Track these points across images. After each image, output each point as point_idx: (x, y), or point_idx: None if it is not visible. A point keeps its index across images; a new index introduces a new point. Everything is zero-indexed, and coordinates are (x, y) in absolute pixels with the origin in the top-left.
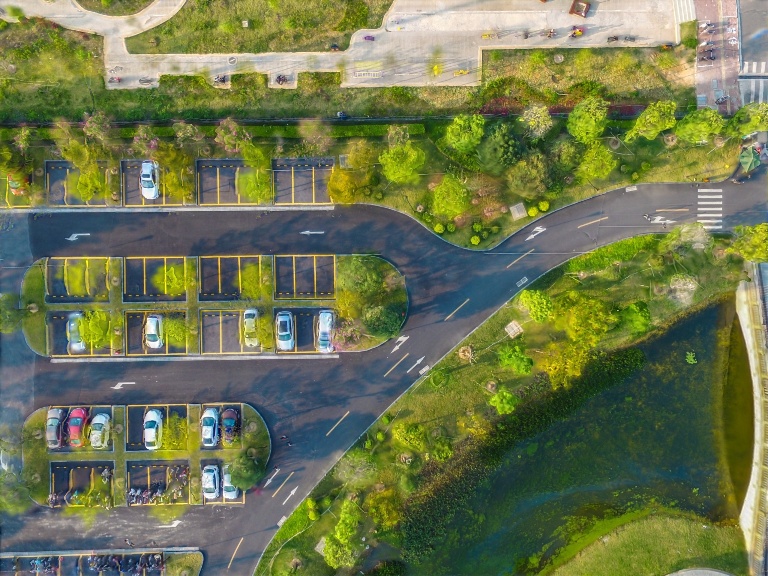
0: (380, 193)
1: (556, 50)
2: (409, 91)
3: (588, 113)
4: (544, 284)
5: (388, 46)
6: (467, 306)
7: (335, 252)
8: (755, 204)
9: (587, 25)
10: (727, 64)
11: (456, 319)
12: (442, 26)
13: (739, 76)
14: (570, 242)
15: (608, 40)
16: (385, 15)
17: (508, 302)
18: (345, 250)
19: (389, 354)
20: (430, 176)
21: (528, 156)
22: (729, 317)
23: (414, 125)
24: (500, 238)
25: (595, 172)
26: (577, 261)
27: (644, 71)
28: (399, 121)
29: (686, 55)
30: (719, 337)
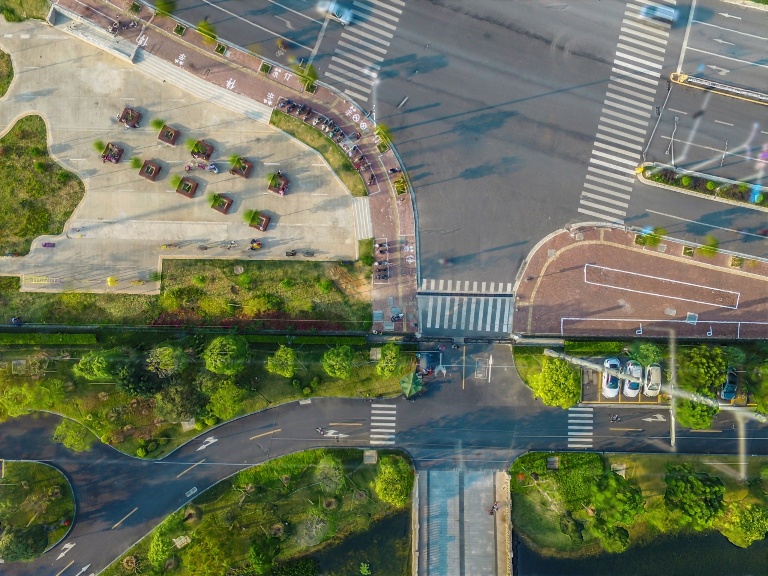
0: (51, 400)
1: (236, 261)
2: (87, 298)
3: (210, 358)
4: (211, 496)
5: (69, 252)
6: (136, 514)
7: (4, 457)
8: (428, 421)
9: (268, 238)
10: (403, 282)
11: (124, 527)
12: (123, 234)
13: (417, 292)
14: (242, 453)
15: (286, 254)
16: (66, 222)
17: (175, 513)
18: (15, 455)
19: (54, 561)
20: (101, 385)
21: (168, 387)
22: (410, 526)
23: (85, 335)
24: (169, 448)
25: (220, 414)
26: (247, 473)
27: (323, 285)
28: (73, 329)
29: (364, 271)
30: (397, 547)
